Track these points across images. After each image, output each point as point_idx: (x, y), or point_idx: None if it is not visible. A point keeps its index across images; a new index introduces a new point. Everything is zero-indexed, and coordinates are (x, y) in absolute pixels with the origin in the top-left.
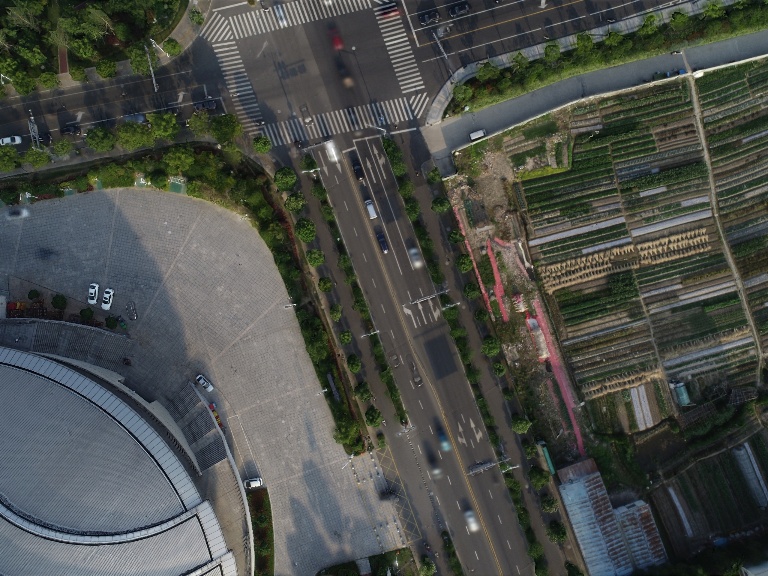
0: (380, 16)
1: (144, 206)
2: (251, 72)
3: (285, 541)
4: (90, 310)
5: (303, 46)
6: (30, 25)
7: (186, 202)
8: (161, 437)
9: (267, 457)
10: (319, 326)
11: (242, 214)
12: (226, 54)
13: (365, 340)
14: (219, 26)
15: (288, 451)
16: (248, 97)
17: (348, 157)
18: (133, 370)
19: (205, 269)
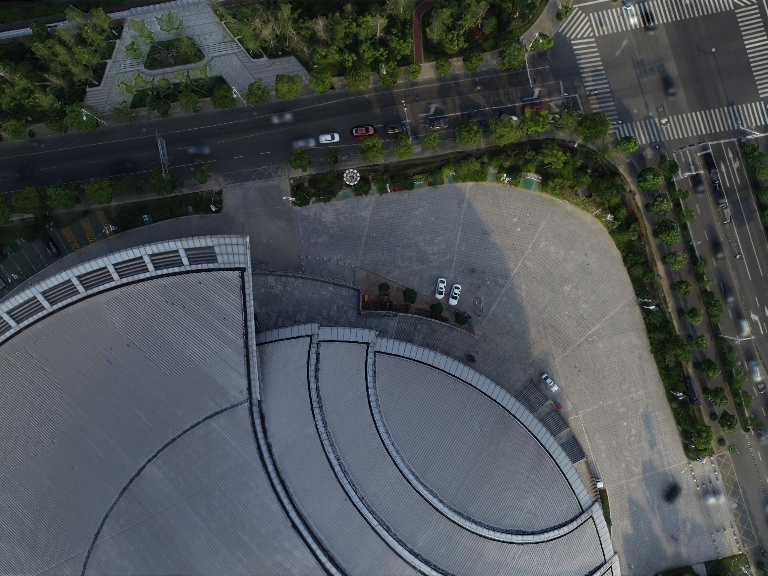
0: (742, 18)
1: (494, 202)
2: (609, 70)
3: (622, 543)
4: (441, 305)
5: (663, 46)
6: (400, 14)
7: (536, 199)
8: (553, 437)
9: (607, 459)
10: (672, 329)
11: (605, 214)
12: (585, 51)
13: (710, 345)
14: (579, 22)
15: (629, 453)
16: (605, 95)
17: (703, 160)
18: (476, 367)
19: (553, 268)
